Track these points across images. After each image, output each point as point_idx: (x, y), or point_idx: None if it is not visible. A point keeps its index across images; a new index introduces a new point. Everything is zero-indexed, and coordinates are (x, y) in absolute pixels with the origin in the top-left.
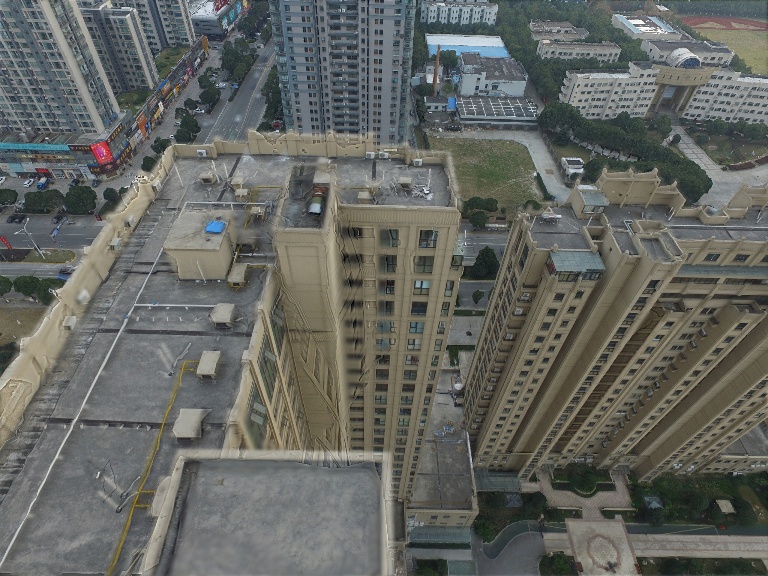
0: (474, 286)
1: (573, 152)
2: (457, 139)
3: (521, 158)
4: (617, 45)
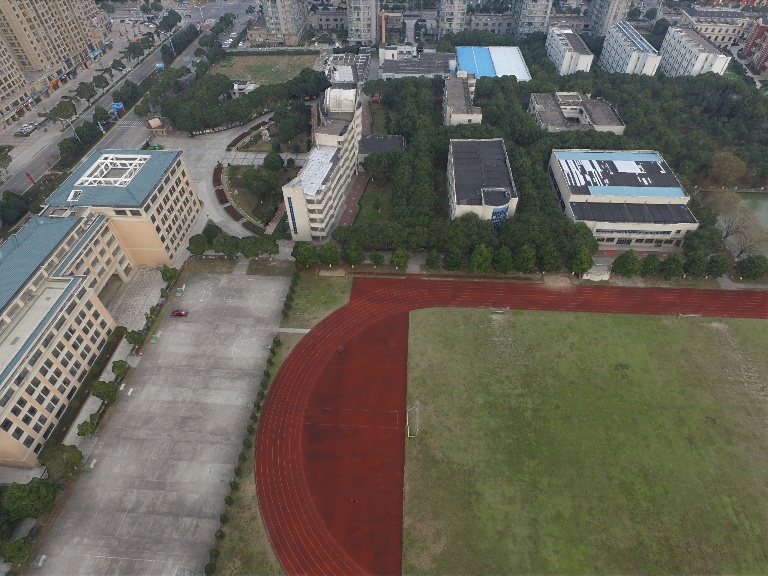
0: (161, 59)
1: None
2: (313, 64)
3: (277, 82)
4: (468, 114)
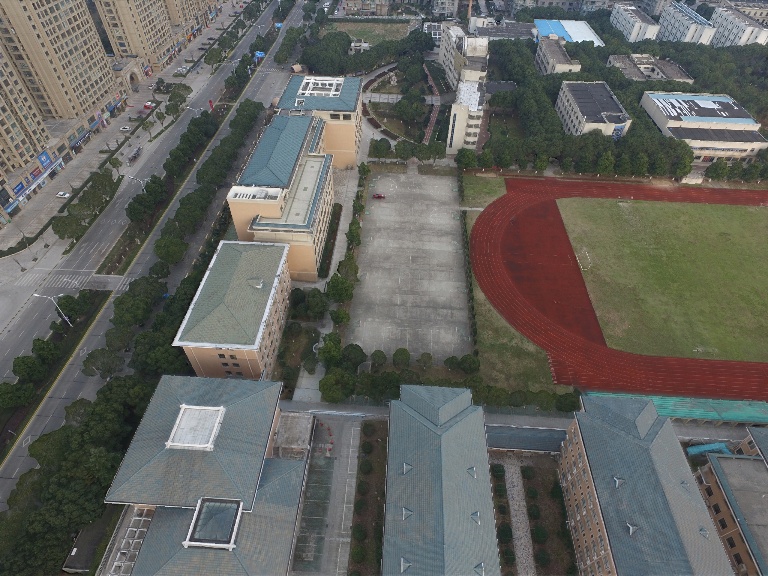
0: (270, 22)
1: (389, 57)
2: (406, 30)
3: None
4: None
